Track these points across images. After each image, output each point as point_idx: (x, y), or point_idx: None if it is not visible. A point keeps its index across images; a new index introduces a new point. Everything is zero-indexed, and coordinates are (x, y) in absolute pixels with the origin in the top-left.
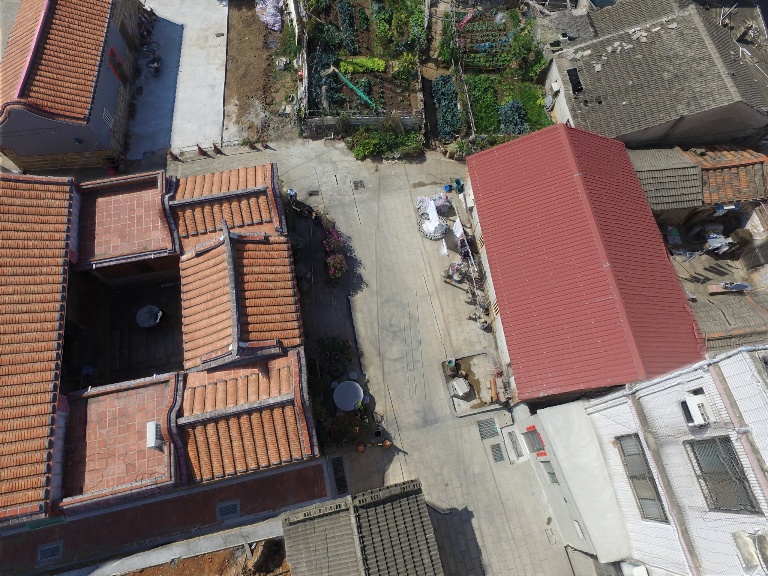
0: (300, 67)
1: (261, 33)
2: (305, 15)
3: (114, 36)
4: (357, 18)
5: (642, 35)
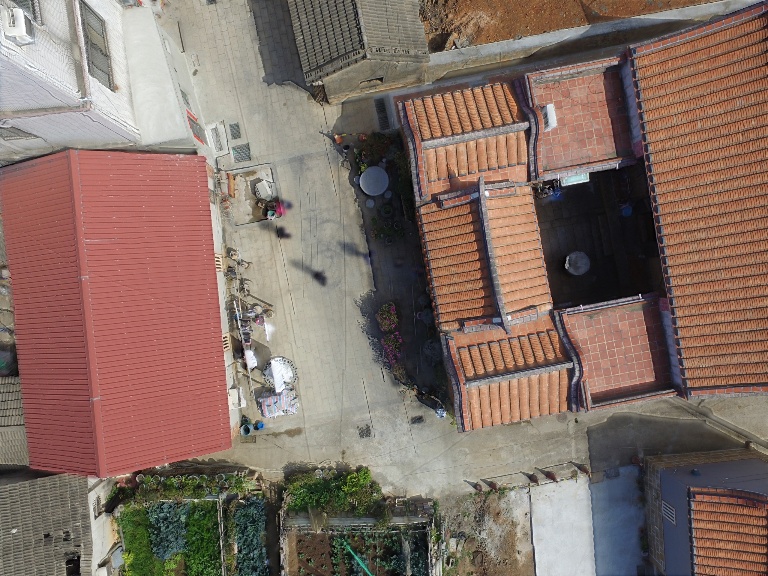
0: None
1: None
2: None
3: None
4: None
5: None
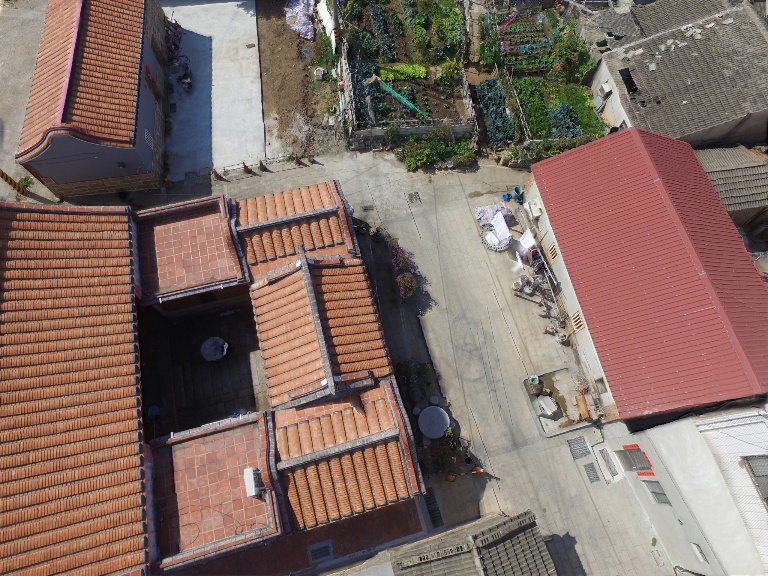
0: (339, 77)
1: (294, 42)
2: (342, 22)
3: (147, 52)
4: (391, 23)
5: (696, 32)
